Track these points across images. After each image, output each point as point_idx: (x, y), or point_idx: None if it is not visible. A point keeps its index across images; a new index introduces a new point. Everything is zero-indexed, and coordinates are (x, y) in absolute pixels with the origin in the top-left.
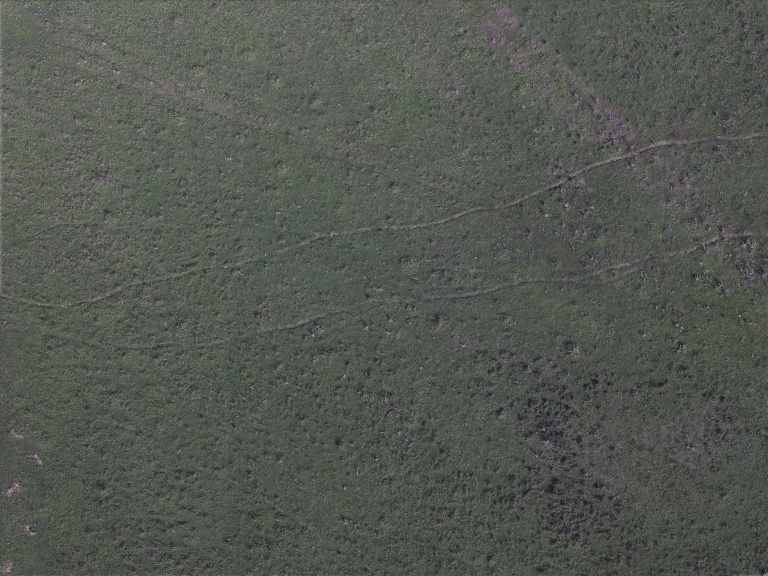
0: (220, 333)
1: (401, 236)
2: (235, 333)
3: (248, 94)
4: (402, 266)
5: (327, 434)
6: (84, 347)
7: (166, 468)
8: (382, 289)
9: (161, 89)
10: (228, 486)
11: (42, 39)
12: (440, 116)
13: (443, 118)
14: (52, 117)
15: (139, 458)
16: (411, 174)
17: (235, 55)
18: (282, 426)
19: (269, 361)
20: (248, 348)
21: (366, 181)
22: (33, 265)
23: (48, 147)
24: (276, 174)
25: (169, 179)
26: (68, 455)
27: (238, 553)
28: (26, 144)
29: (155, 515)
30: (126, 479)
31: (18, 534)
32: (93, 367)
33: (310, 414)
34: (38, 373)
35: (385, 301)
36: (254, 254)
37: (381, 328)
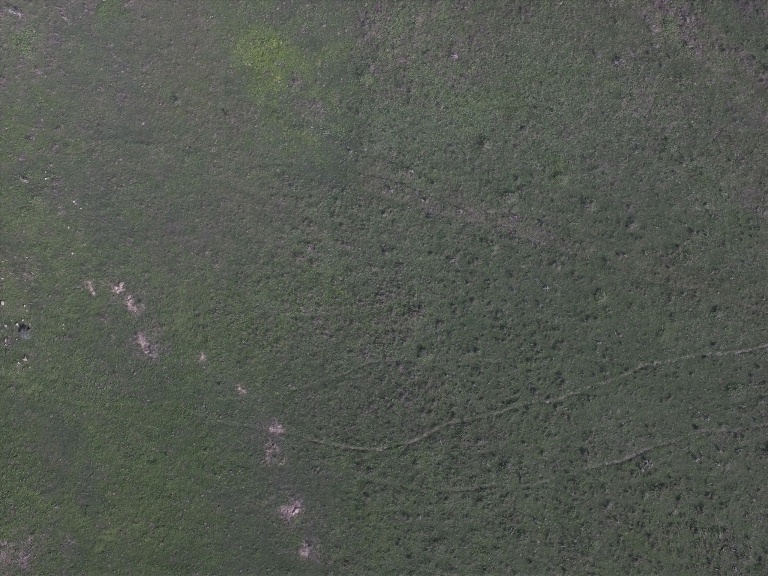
0: (545, 472)
1: (726, 362)
2: (561, 471)
3: (562, 219)
4: (730, 394)
5: (661, 574)
6: (403, 492)
7: None
8: (710, 418)
9: (471, 217)
10: None
11: (343, 168)
12: (760, 236)
13: (763, 238)
14: (358, 250)
15: None
16: (733, 297)
17: (546, 179)
18: (615, 568)
19: (598, 499)
20: (576, 487)
21: (688, 306)
22: (344, 407)
23: (355, 281)
24: (595, 302)
25: (484, 311)
26: None
27: None
28: (332, 279)
29: None
30: None
31: None
32: (413, 513)
33: (643, 554)
34: (355, 521)
35: (713, 431)
36: (576, 387)
37: (711, 460)
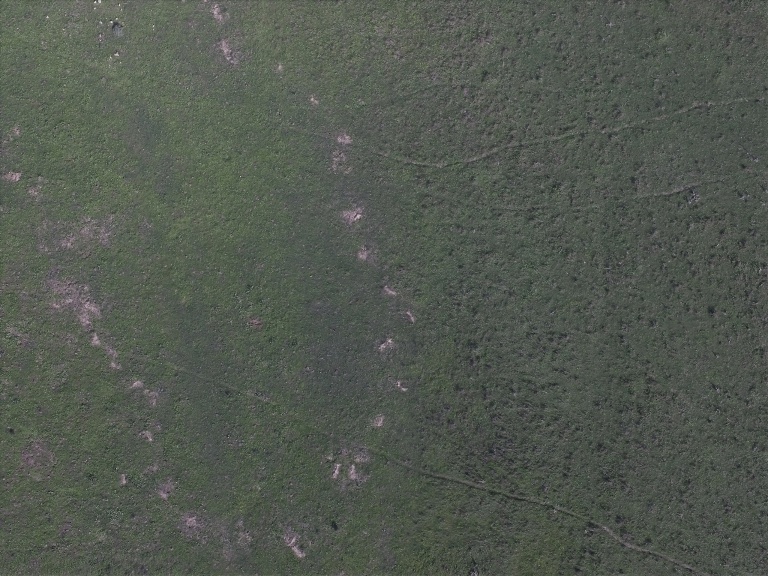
0: (596, 197)
1: None
2: (611, 198)
3: None
4: None
5: (700, 302)
6: (459, 207)
7: (538, 329)
8: (758, 160)
9: None
10: (599, 350)
11: None
12: None
13: None
14: None
15: (512, 318)
16: None
17: None
18: (656, 292)
19: (644, 227)
20: (624, 213)
21: (745, 52)
22: (409, 124)
23: (427, 7)
24: (656, 41)
25: (549, 43)
26: (439, 313)
27: (608, 417)
28: (405, 4)
29: (526, 376)
30: (497, 339)
31: (389, 389)
32: (467, 227)
33: (684, 281)
34: (412, 231)
35: (760, 172)
36: (631, 120)
37: (756, 199)
